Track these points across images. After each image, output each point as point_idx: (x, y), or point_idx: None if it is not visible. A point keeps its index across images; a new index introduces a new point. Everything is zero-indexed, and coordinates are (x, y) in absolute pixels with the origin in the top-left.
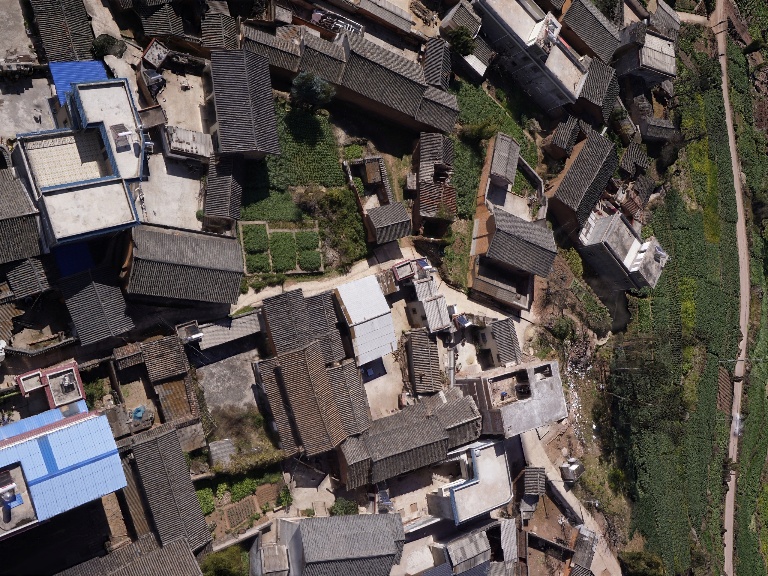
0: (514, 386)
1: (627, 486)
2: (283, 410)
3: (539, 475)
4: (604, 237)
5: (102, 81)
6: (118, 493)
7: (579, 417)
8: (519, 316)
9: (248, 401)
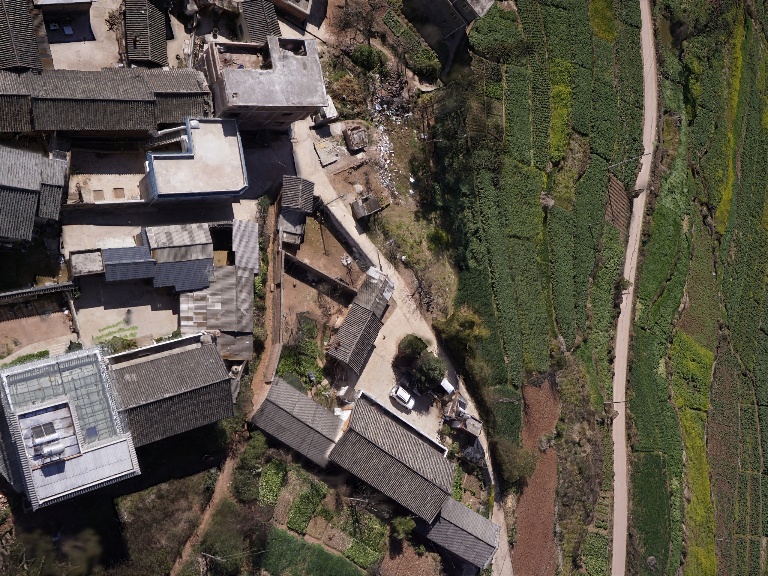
0: (259, 65)
1: (454, 253)
2: None
3: (302, 187)
4: None
5: None
6: None
7: (390, 164)
8: (304, 29)
9: None
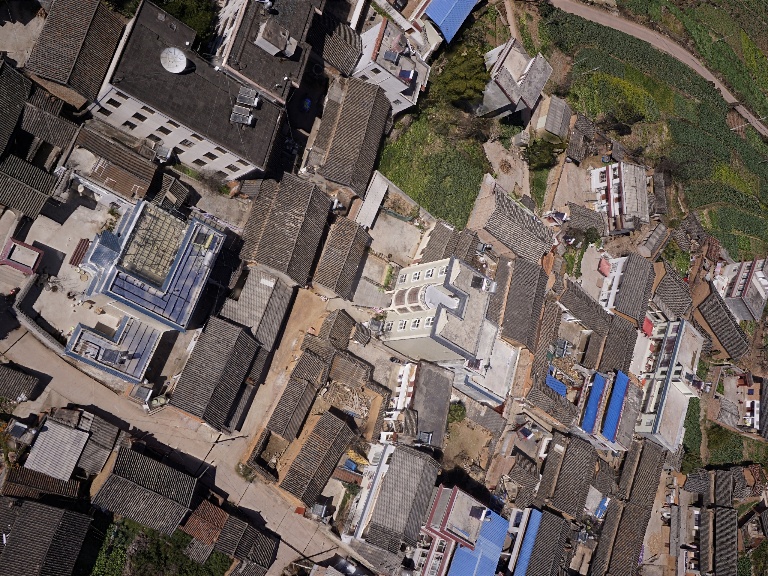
0: None
1: None
2: None
3: None
4: (756, 318)
5: None
6: None
7: None
8: None
9: None
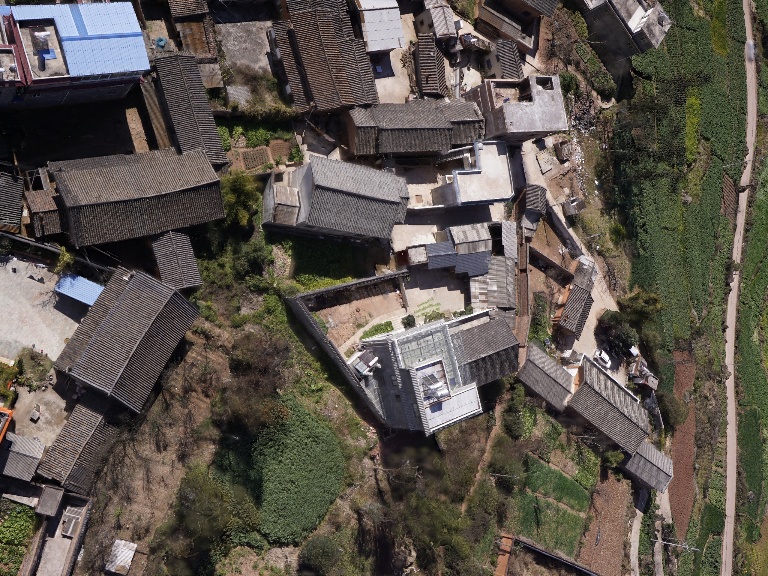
0: (517, 97)
1: (628, 242)
2: (295, 70)
3: (540, 193)
4: None
5: None
6: (142, 116)
7: (582, 170)
8: (524, 59)
9: (263, 65)
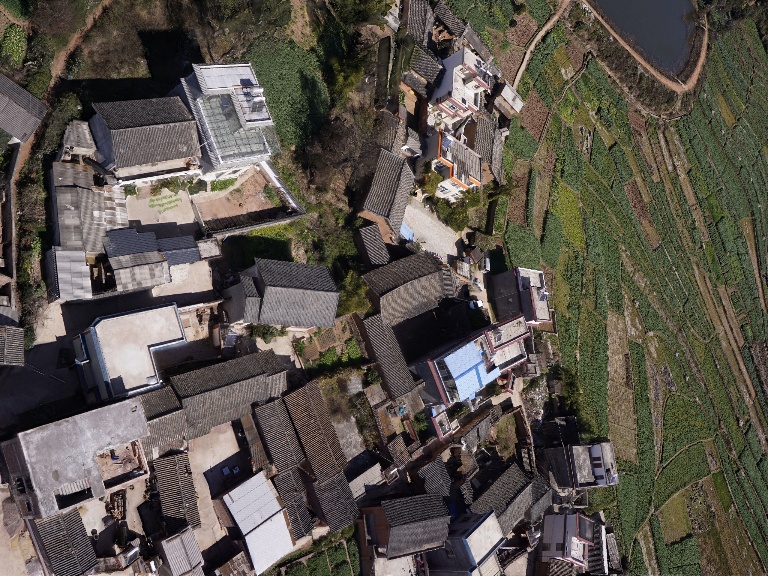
0: None
1: None
2: None
3: (2, 353)
4: None
5: None
6: None
7: None
8: None
9: None
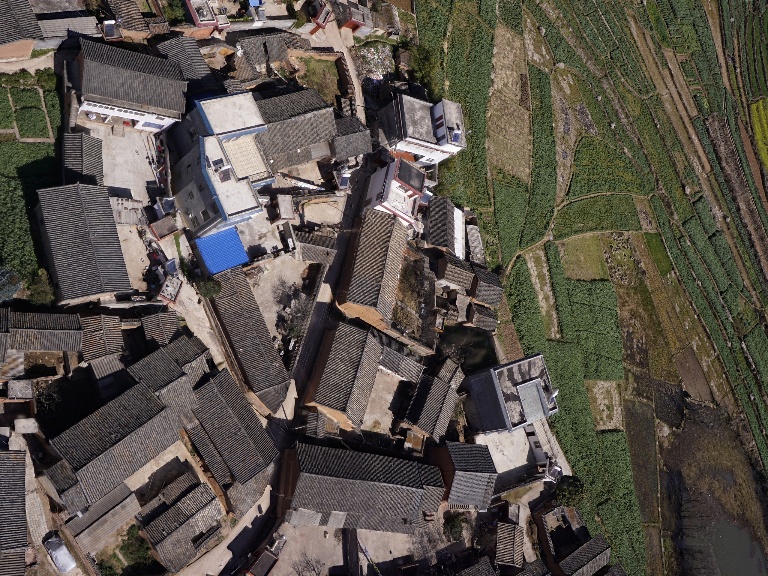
0: None
1: None
2: None
3: None
4: None
5: (244, 215)
6: None
7: None
8: None
9: None
